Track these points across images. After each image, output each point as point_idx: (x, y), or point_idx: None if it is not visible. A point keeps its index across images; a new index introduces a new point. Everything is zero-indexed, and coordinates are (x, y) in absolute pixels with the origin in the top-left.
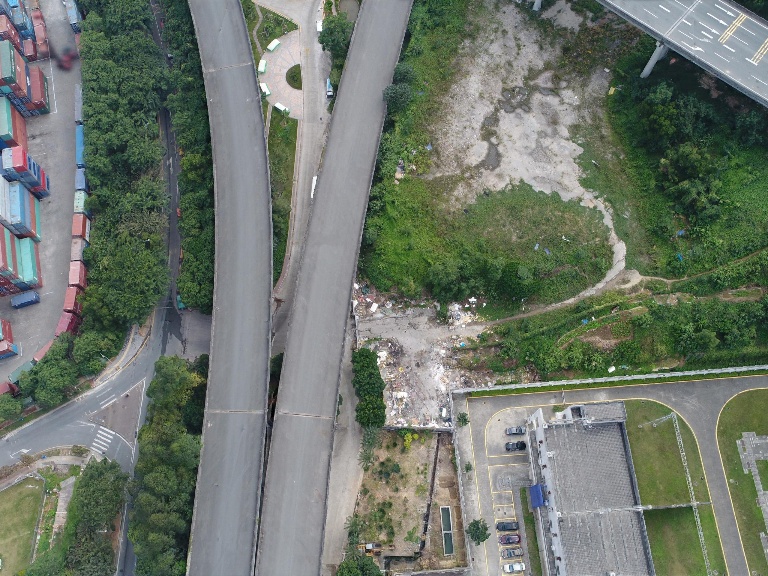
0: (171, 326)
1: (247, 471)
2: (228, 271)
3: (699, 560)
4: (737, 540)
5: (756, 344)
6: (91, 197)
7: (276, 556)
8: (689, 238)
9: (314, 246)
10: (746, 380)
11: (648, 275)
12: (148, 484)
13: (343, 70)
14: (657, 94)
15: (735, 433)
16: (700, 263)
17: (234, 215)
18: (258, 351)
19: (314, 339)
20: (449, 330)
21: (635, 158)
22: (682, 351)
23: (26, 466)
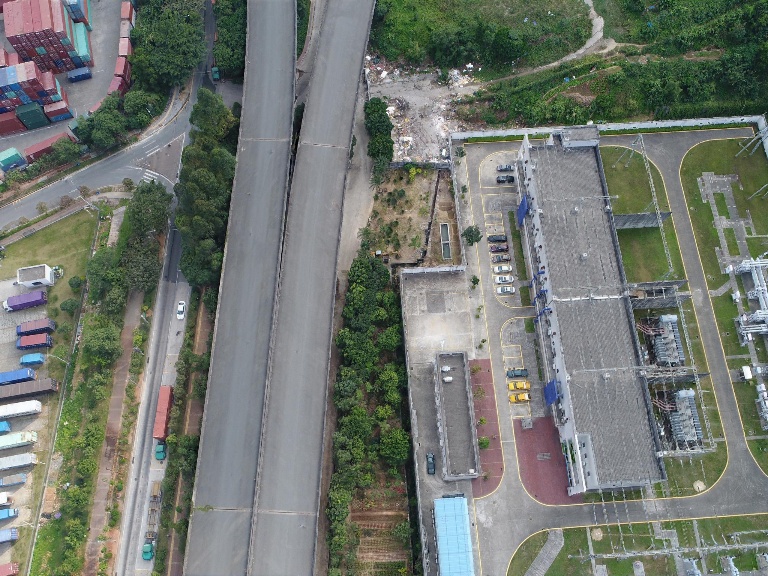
0: None
1: (275, 184)
2: (258, 34)
3: (662, 266)
4: (695, 252)
5: (716, 99)
6: None
7: (300, 249)
8: (658, 11)
9: (332, 17)
10: (707, 133)
11: (622, 42)
12: (193, 177)
13: None
14: None
15: (696, 172)
16: (667, 29)
17: None
18: (284, 94)
19: (332, 88)
20: (449, 89)
21: None
22: (651, 106)
23: (83, 200)
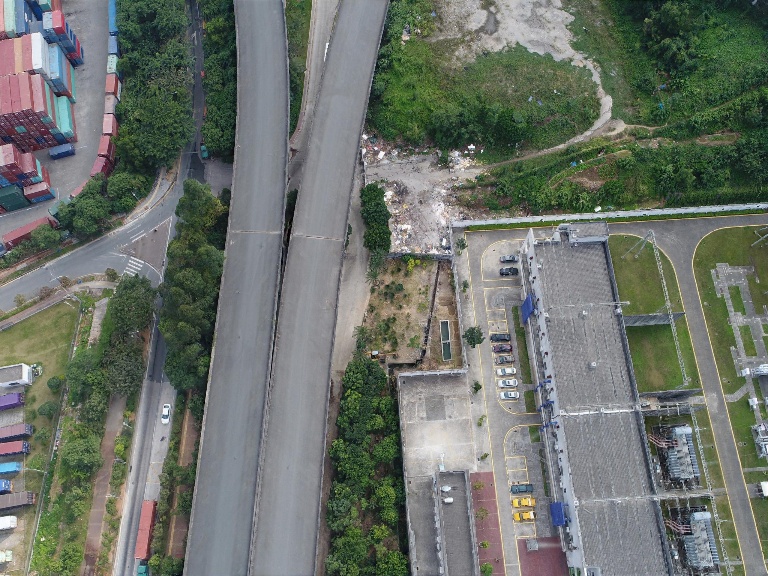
0: (195, 173)
1: (265, 281)
2: (249, 115)
3: (674, 368)
4: (709, 352)
5: (730, 185)
6: (123, 59)
7: (291, 353)
8: (670, 91)
9: (327, 96)
10: (721, 220)
11: (632, 123)
12: (178, 280)
13: None
14: None
15: (710, 264)
16: (679, 111)
17: (254, 68)
18: (276, 182)
19: (326, 174)
20: (449, 173)
21: (622, 24)
22: (662, 192)
23: (64, 290)
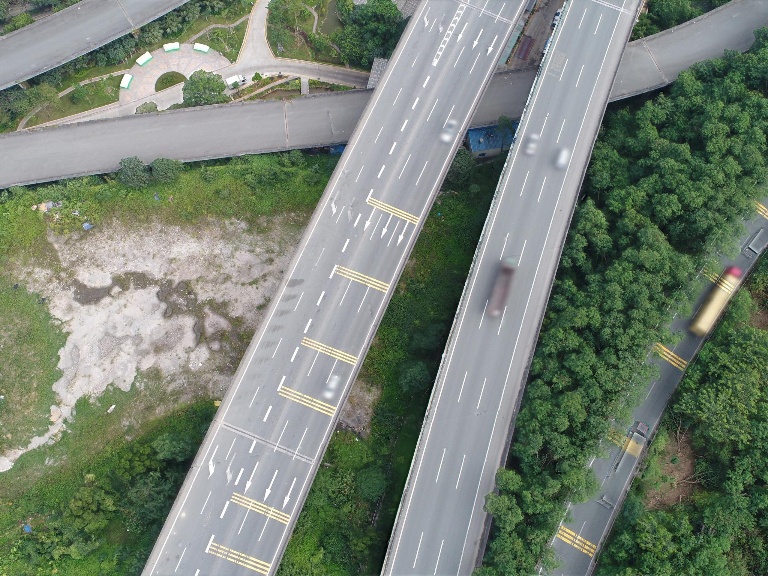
0: None
1: None
2: None
3: None
4: None
5: None
6: None
7: None
8: None
9: None
10: None
11: None
12: None
13: (155, 111)
14: (161, 441)
15: None
16: None
17: None
18: None
19: None
20: None
21: None
22: None
23: None
